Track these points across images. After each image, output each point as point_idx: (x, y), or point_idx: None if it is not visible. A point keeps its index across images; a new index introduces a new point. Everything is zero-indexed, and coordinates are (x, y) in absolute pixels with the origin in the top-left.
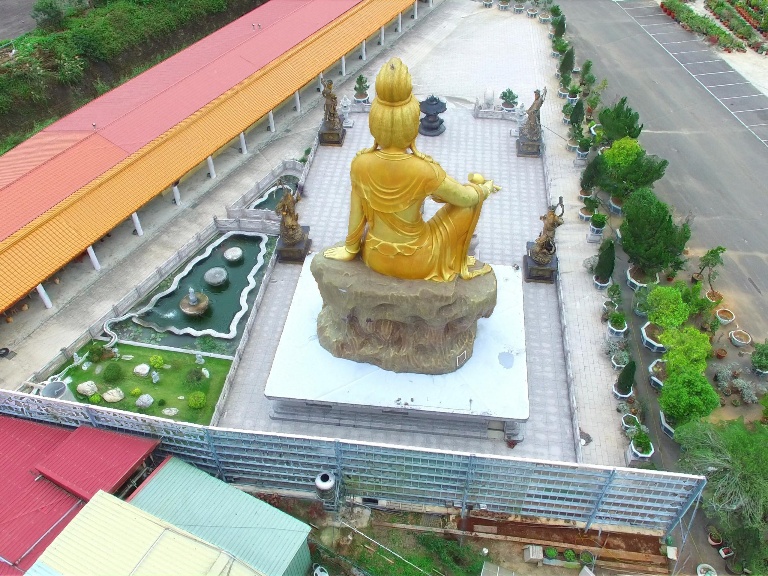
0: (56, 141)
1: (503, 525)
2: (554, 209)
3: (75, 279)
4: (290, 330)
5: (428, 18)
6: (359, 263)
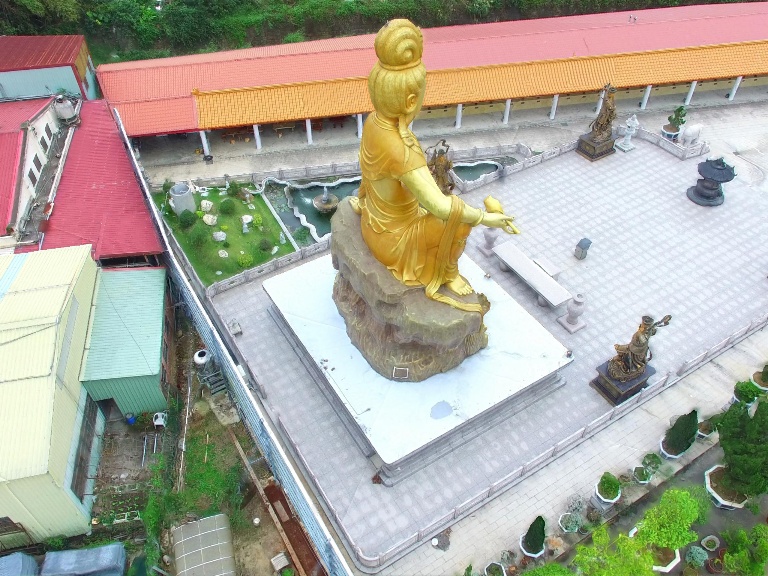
0: None
1: (294, 522)
2: (648, 322)
3: (291, 141)
4: None
5: None
6: None
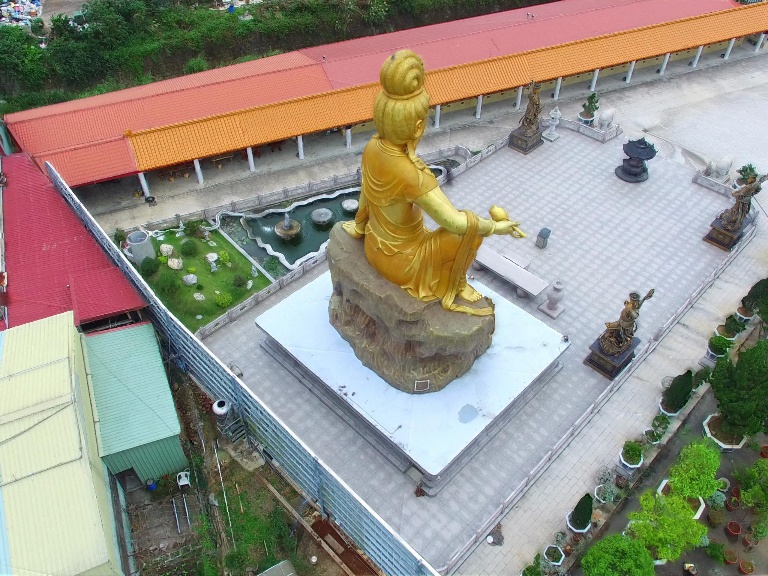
0: (294, 60)
1: (350, 552)
2: (635, 298)
3: (232, 171)
4: (319, 283)
5: (741, 62)
6: (361, 244)
